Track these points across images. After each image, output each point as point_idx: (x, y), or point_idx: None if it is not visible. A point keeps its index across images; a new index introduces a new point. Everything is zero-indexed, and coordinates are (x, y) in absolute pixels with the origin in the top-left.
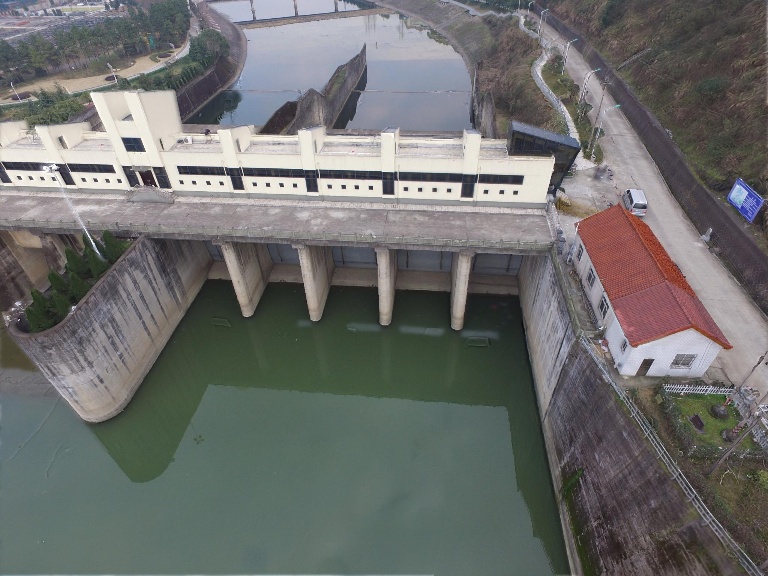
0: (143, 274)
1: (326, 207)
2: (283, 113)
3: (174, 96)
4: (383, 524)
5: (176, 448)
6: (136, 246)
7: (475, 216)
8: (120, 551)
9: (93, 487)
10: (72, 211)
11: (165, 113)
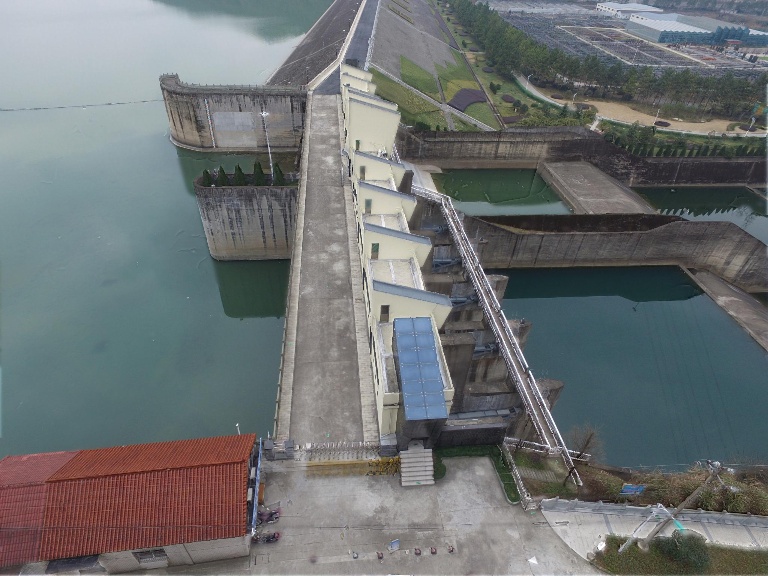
0: (281, 207)
1: (350, 257)
2: (650, 221)
3: (398, 119)
4: (97, 410)
5: (249, 318)
6: (285, 188)
7: (352, 369)
8: (124, 292)
9: (168, 269)
10: (324, 156)
11: (376, 126)
